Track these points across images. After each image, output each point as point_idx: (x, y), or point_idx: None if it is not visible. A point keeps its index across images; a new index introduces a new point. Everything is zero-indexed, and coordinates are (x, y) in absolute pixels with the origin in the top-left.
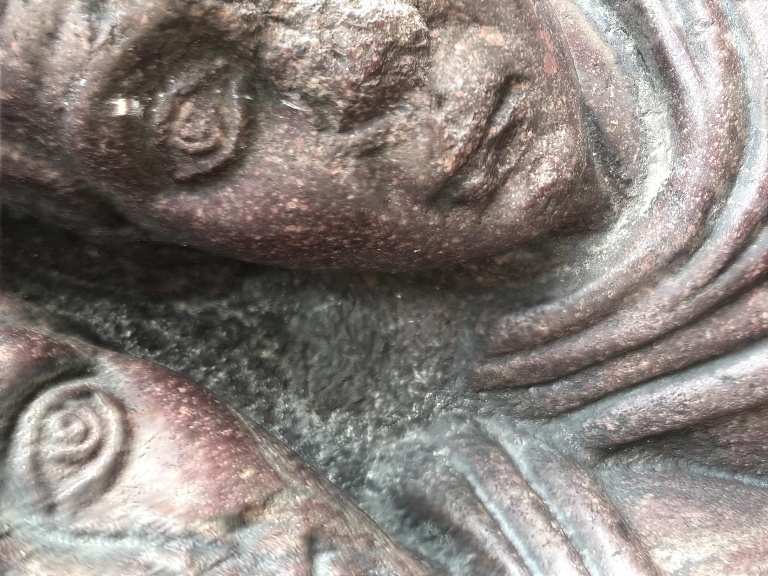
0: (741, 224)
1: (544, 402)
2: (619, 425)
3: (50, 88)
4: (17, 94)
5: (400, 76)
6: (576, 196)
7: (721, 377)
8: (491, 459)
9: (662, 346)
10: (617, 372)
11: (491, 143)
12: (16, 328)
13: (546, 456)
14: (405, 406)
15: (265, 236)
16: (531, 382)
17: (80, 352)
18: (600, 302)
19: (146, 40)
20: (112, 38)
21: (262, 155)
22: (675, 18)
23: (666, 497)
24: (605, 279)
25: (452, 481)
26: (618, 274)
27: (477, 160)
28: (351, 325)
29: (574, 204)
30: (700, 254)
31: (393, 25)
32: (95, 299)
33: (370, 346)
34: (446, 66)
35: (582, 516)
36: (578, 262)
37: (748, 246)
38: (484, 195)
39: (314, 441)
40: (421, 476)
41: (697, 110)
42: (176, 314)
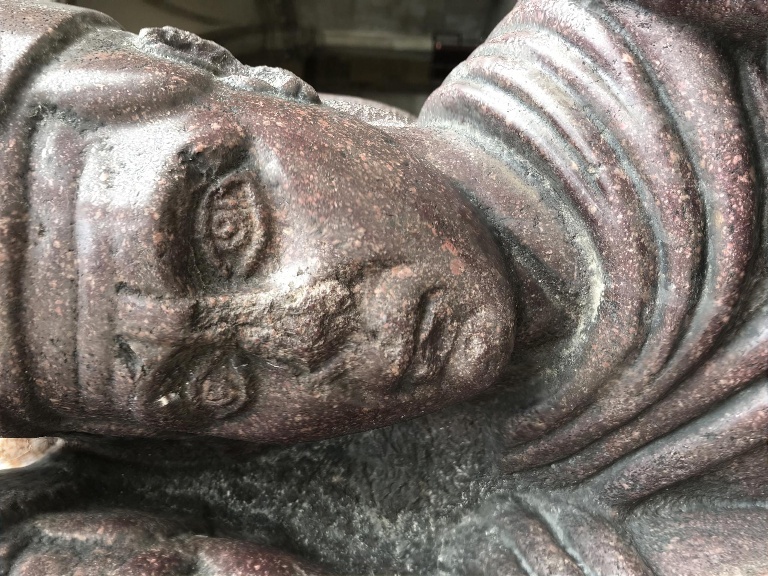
0: (671, 320)
1: (567, 474)
2: (634, 484)
3: (118, 402)
4: (100, 407)
5: (339, 330)
6: (535, 317)
7: (705, 434)
8: (531, 533)
9: (646, 418)
10: (617, 443)
11: (425, 343)
12: (140, 554)
13: (578, 521)
14: (455, 496)
15: (289, 436)
16: (549, 462)
17: (185, 555)
18: (579, 397)
19: (165, 366)
20: (144, 372)
21: (267, 393)
22: (570, 165)
23: (691, 538)
24: (577, 379)
25: (502, 558)
26: (586, 373)
27: (418, 358)
28: (394, 442)
29: (535, 324)
30: (647, 347)
31: (321, 304)
32: (198, 474)
33: (414, 455)
34: (371, 309)
35: (610, 574)
36: (555, 365)
37: (684, 334)
38: (434, 376)
39: (389, 540)
40: (478, 556)
41: (607, 237)
42: (259, 466)
